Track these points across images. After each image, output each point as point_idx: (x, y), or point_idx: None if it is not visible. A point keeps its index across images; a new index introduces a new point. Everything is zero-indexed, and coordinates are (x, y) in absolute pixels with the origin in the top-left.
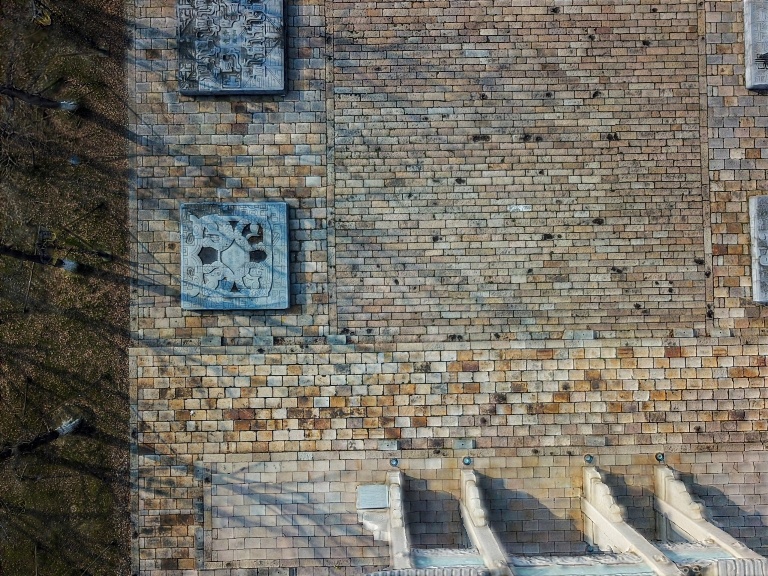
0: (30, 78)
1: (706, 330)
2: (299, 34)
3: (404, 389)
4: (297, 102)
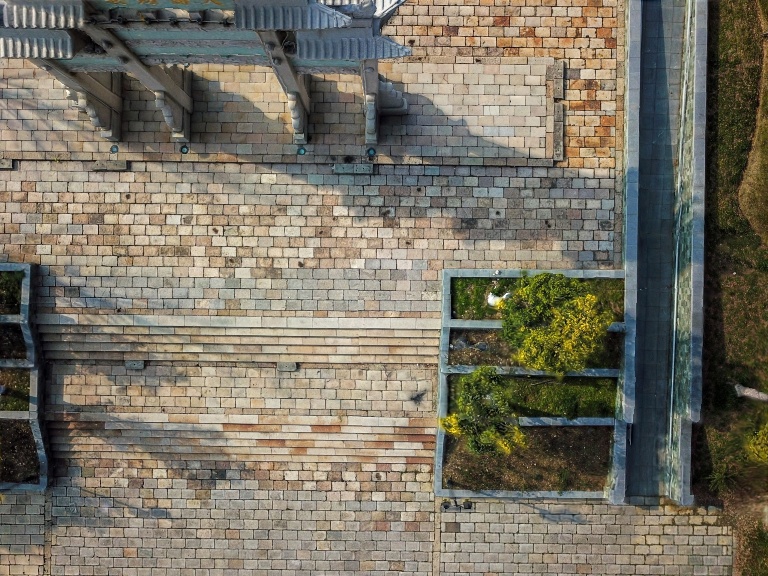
0: None
1: None
2: None
3: None
4: None
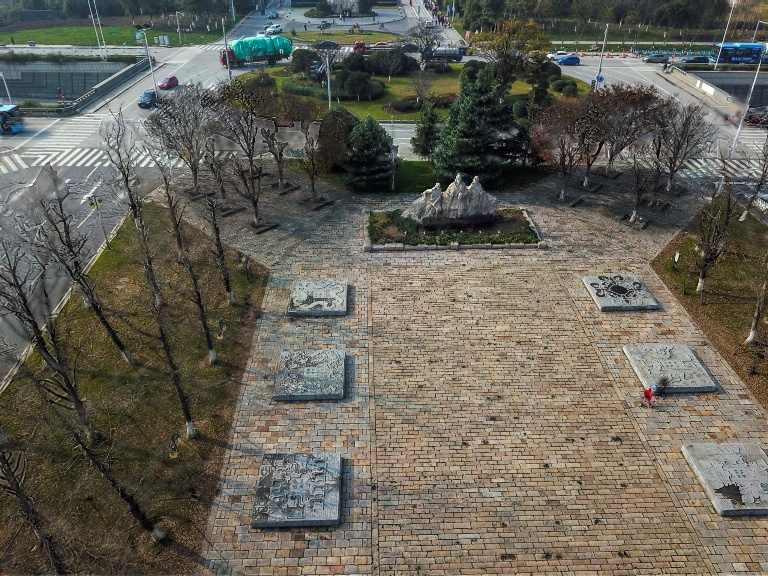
0: (131, 516)
1: None
2: (351, 484)
3: None
4: (347, 531)
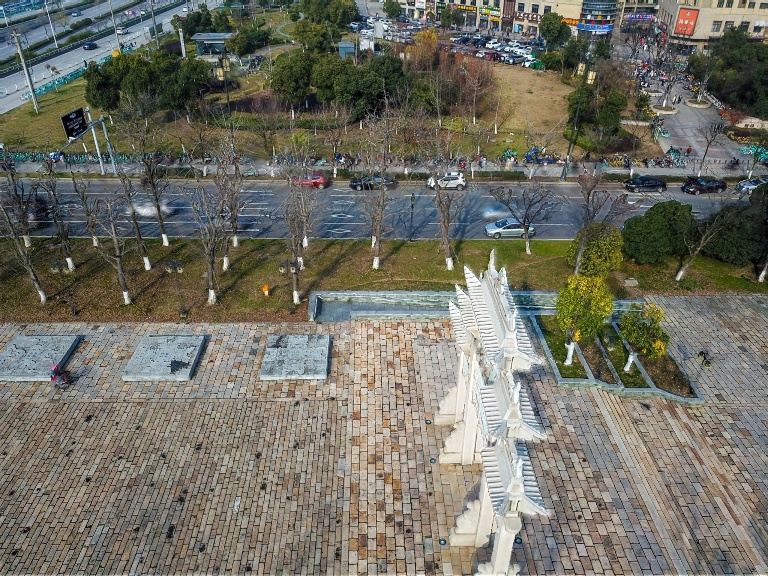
0: None
1: (343, 400)
2: None
3: None
4: None
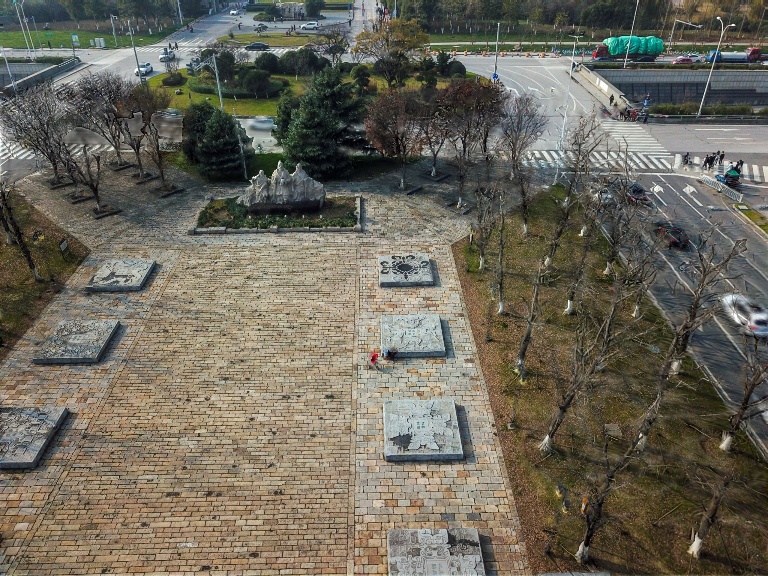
0: None
1: None
2: (65, 434)
3: None
4: (40, 473)
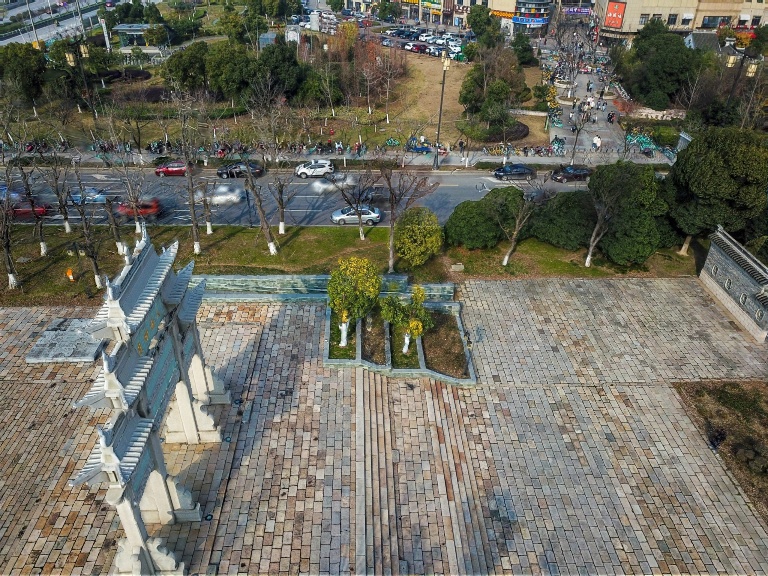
0: None
1: None
2: None
3: (46, 572)
4: None
